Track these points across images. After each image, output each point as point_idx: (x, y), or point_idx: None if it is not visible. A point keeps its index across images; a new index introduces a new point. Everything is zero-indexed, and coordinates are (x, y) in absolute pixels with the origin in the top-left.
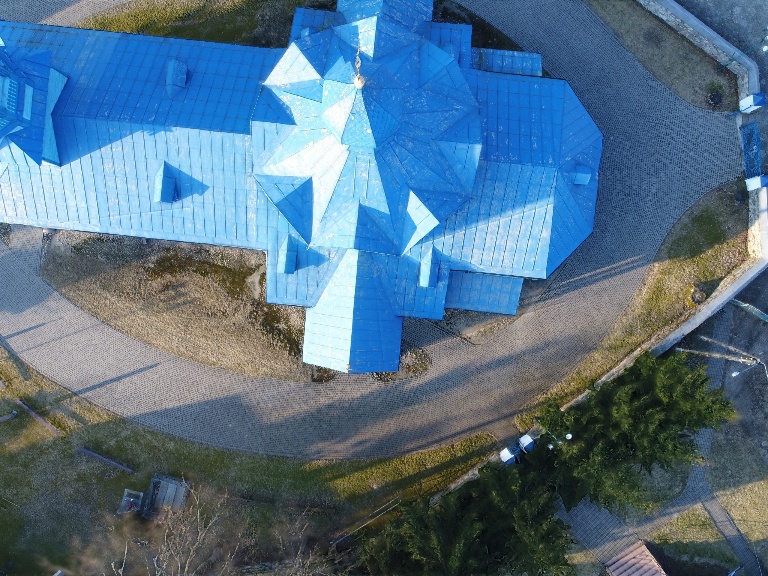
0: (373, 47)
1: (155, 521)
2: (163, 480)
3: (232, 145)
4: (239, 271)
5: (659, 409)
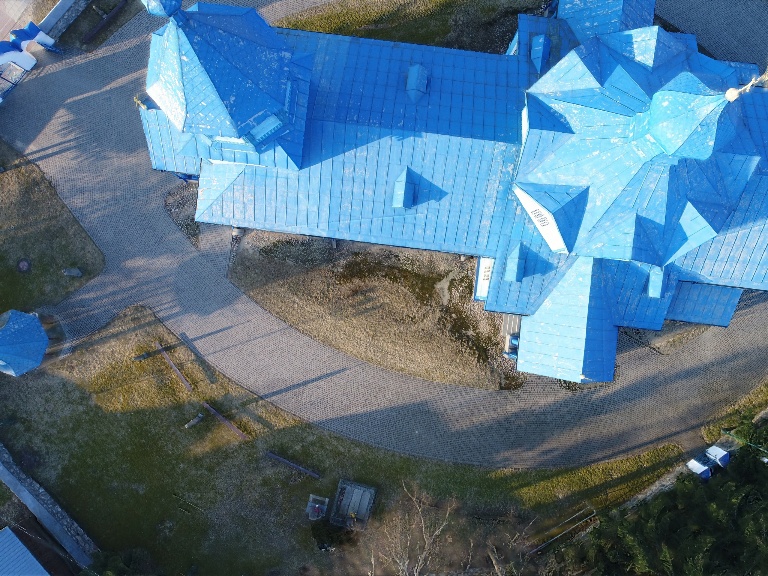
0: (653, 57)
1: (348, 528)
2: (352, 486)
3: (480, 152)
4: (428, 277)
5: None
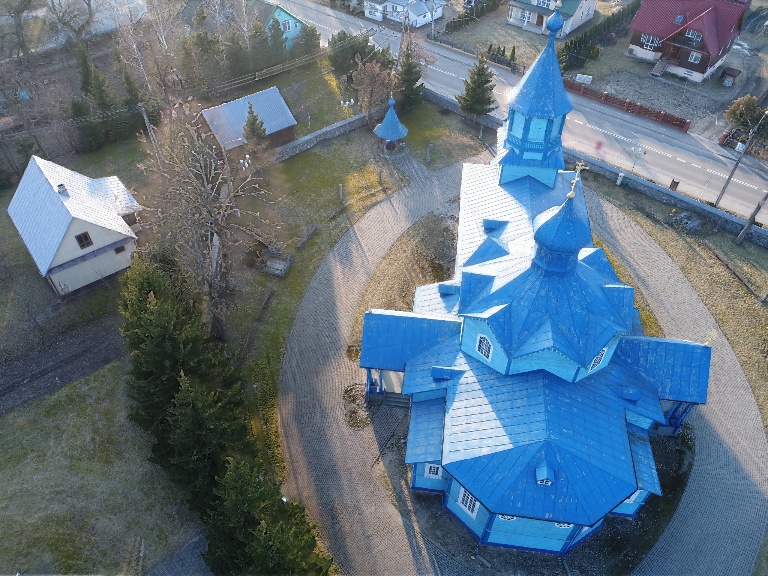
0: None
1: None
2: None
3: None
4: None
5: (306, 567)
